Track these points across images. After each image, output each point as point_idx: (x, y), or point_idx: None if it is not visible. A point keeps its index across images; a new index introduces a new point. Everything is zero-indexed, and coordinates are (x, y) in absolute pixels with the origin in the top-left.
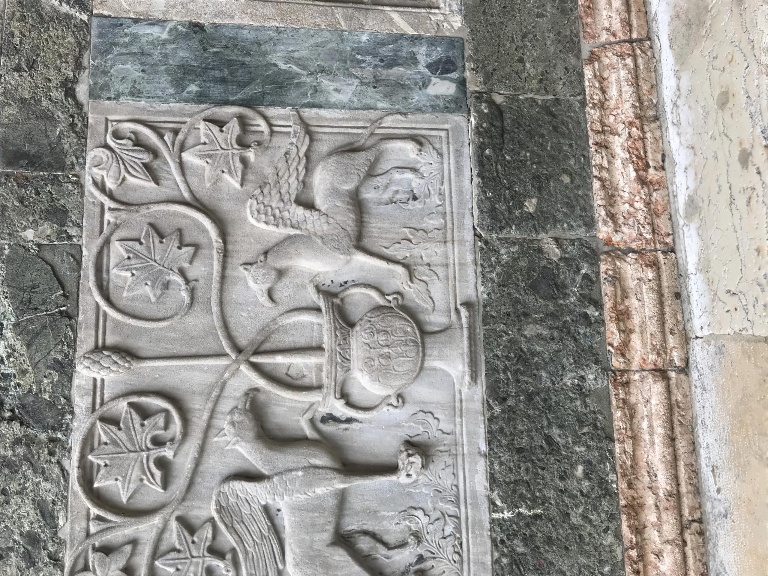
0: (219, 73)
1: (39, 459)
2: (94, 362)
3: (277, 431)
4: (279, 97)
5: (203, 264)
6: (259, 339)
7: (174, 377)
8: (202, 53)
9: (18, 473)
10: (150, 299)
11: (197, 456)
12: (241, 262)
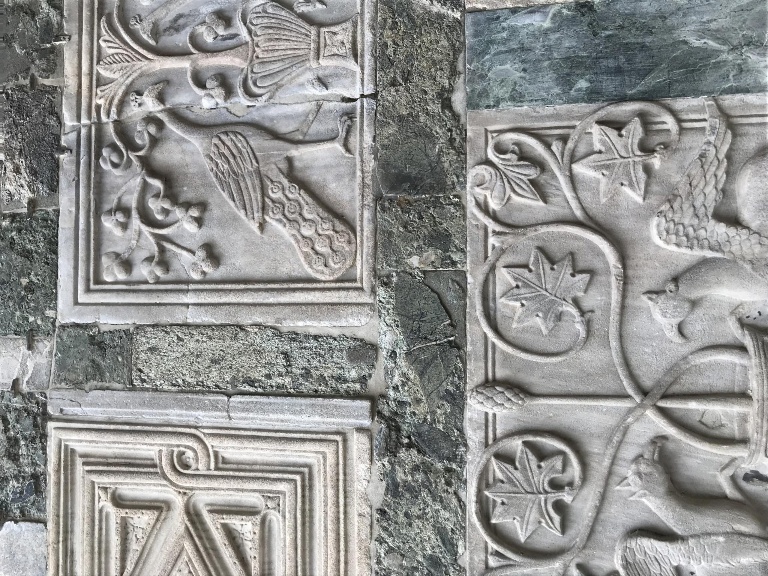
0: (613, 62)
1: (437, 488)
2: (488, 398)
3: (689, 485)
4: (690, 84)
5: (599, 293)
6: (668, 381)
7: (569, 417)
8: (592, 39)
9: (418, 499)
10: (541, 331)
11: (598, 505)
12: (643, 290)
